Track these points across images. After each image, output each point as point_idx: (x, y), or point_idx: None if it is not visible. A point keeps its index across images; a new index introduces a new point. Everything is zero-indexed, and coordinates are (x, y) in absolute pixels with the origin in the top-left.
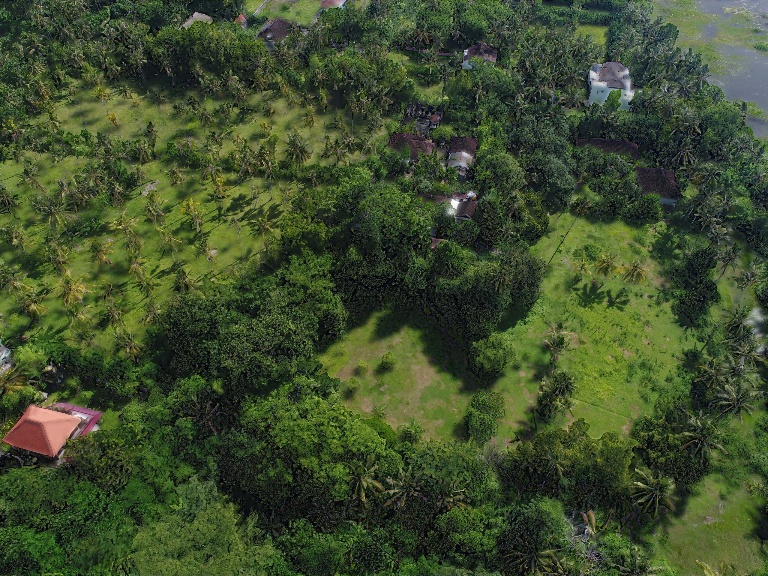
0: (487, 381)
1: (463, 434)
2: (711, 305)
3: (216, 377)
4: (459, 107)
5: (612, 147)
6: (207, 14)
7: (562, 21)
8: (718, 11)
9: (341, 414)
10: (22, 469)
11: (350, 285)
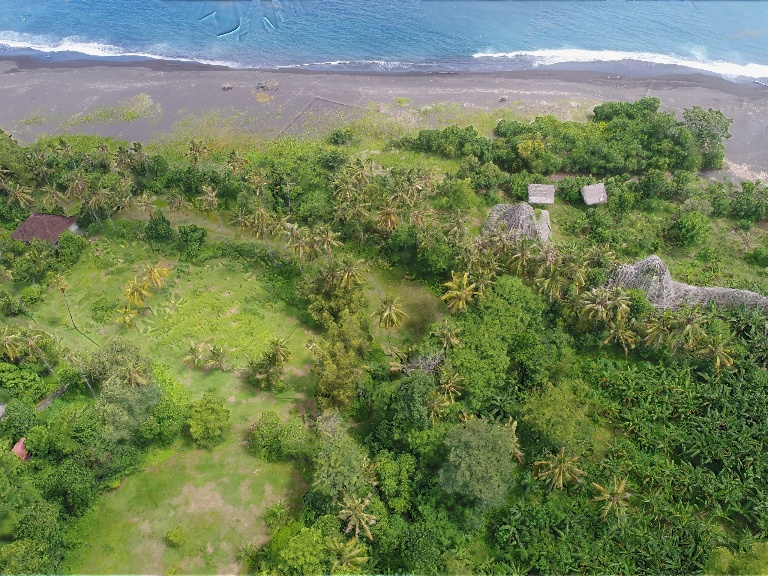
0: (231, 434)
1: (286, 467)
2: (204, 240)
3: None
4: None
5: None
6: None
7: None
8: None
9: (267, 575)
10: None
11: None
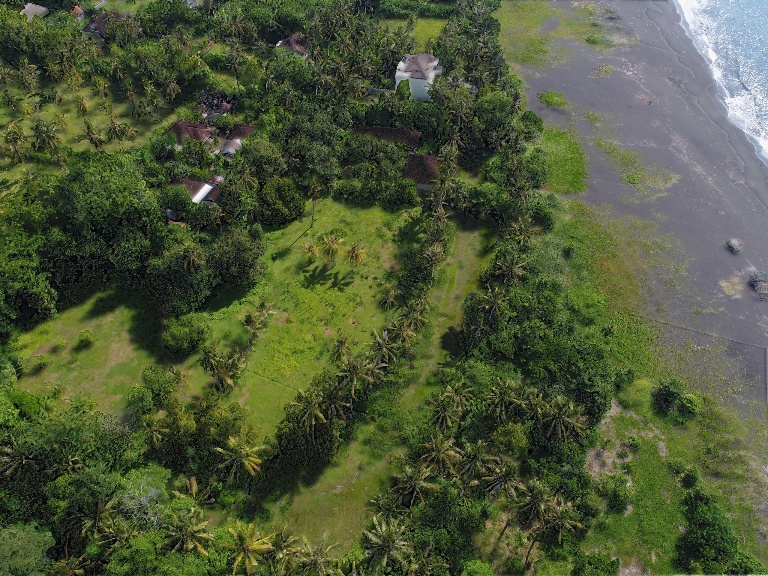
0: (180, 358)
1: None
2: (431, 286)
3: None
4: (253, 96)
5: (391, 135)
6: (49, 5)
7: (405, 14)
8: (566, 5)
9: None
10: None
11: (70, 266)
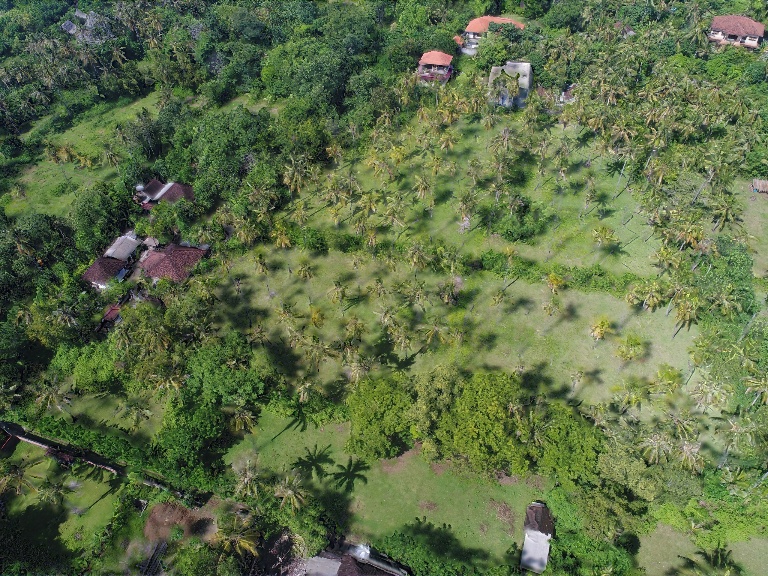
0: None
1: (225, 104)
2: None
3: None
4: None
5: None
6: None
7: None
8: None
9: None
10: (437, 51)
11: None
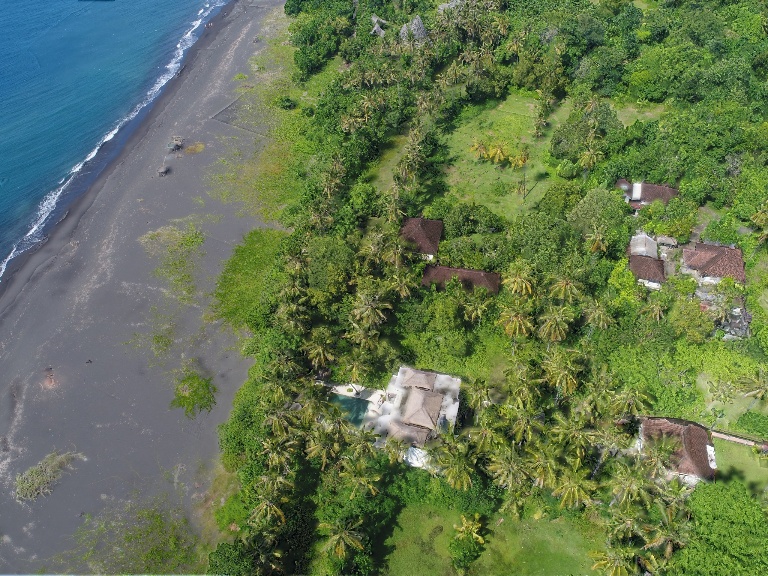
0: None
1: None
2: None
3: (748, 104)
4: None
5: None
6: None
7: None
8: None
9: None
10: None
11: None
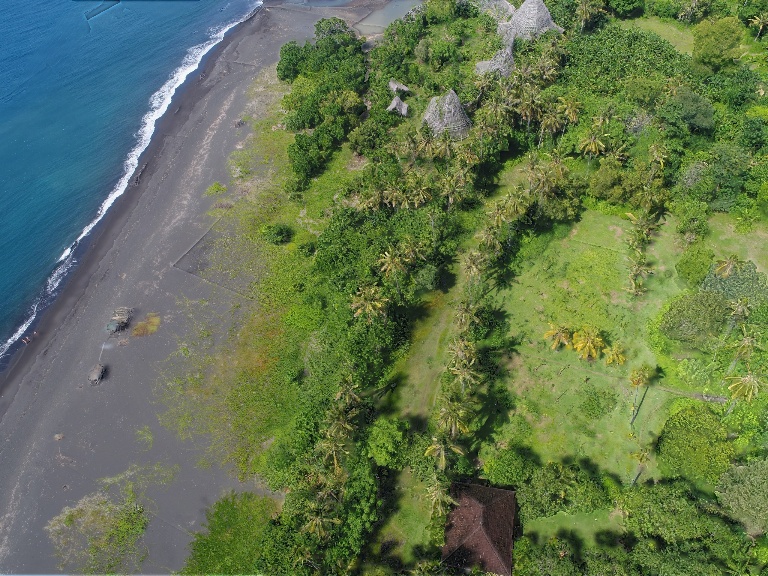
0: None
1: None
2: None
3: None
4: None
5: None
6: None
7: None
8: None
9: None
10: None
11: None
